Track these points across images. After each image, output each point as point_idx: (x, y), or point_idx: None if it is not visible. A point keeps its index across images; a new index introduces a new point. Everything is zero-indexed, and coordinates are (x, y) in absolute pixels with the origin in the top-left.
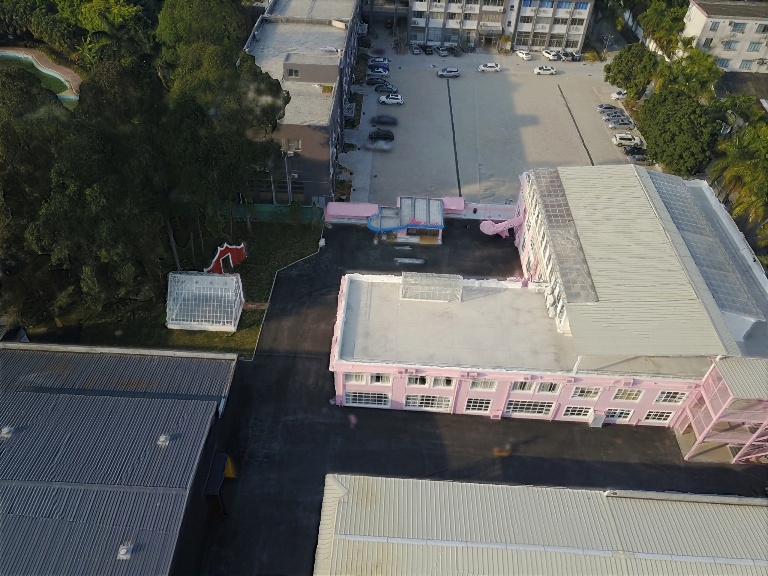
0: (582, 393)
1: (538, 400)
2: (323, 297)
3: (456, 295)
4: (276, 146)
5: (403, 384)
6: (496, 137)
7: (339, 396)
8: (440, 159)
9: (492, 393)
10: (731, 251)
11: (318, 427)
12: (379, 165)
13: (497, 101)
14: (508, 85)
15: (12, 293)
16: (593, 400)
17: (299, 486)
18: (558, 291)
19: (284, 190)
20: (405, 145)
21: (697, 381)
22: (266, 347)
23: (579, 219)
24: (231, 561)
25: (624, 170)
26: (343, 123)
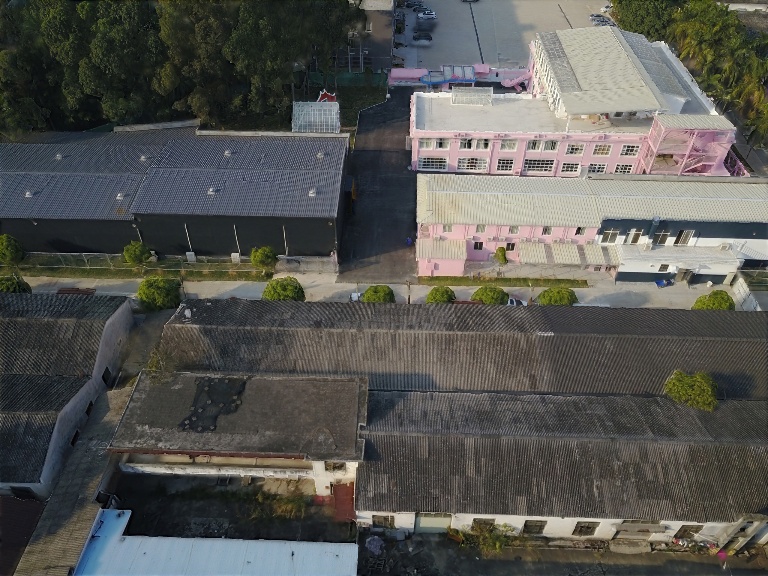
0: (573, 150)
1: (544, 158)
2: (394, 123)
3: (488, 100)
4: (363, 11)
5: (457, 148)
6: (510, 37)
7: (414, 162)
8: (468, 51)
9: (514, 153)
10: (677, 78)
11: (402, 179)
12: (423, 55)
13: (510, 16)
14: (518, 5)
15: (206, 98)
16: (580, 156)
17: (395, 203)
18: (556, 93)
19: (357, 65)
20: (441, 43)
21: (645, 134)
22: (360, 147)
23: (570, 55)
24: (360, 231)
25: (602, 29)
26: (395, 24)
